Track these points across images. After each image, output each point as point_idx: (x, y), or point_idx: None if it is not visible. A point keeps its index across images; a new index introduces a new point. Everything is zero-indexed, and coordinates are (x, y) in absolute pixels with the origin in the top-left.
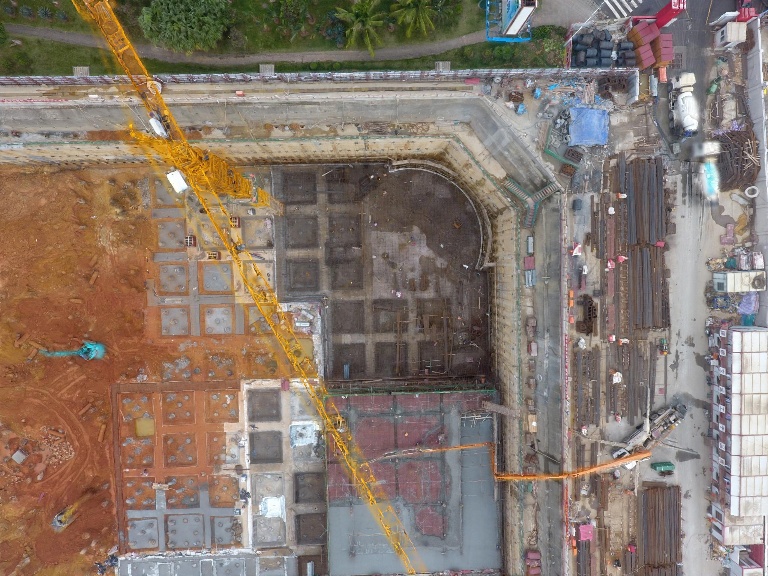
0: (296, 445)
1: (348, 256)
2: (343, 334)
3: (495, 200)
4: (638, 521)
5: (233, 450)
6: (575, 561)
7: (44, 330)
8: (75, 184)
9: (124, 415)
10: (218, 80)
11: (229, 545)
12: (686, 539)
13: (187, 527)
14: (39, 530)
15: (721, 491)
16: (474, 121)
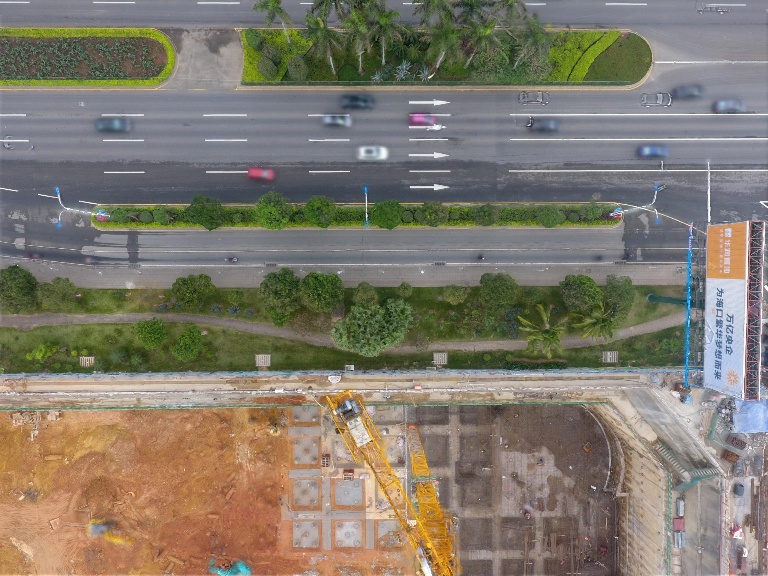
0: None
1: (477, 473)
2: (471, 550)
3: (638, 448)
4: None
5: None
6: None
7: (183, 547)
8: None
9: None
10: (394, 368)
11: None
12: None
13: None
14: None
15: None
16: (630, 392)
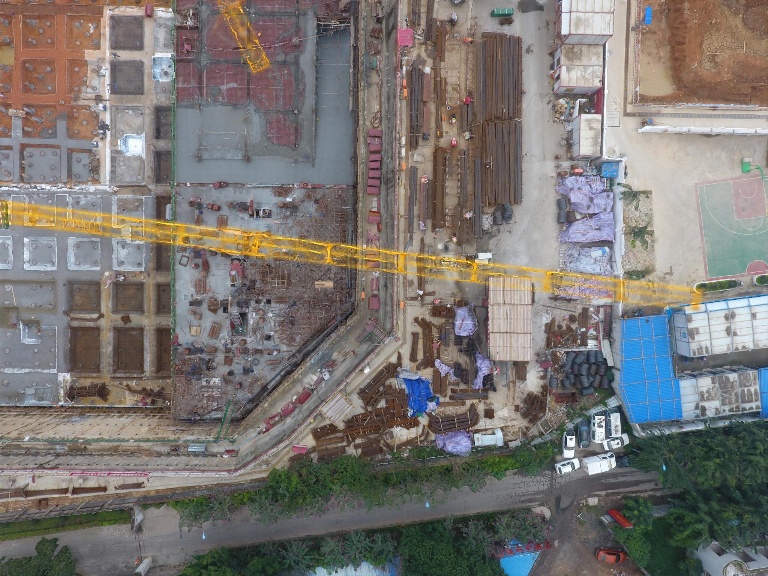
0: (159, 80)
1: None
2: None
3: None
4: (477, 75)
5: (94, 82)
6: (408, 113)
7: None
8: None
9: None
10: None
11: (86, 182)
12: (527, 98)
13: (44, 161)
14: None
15: (557, 23)
16: None
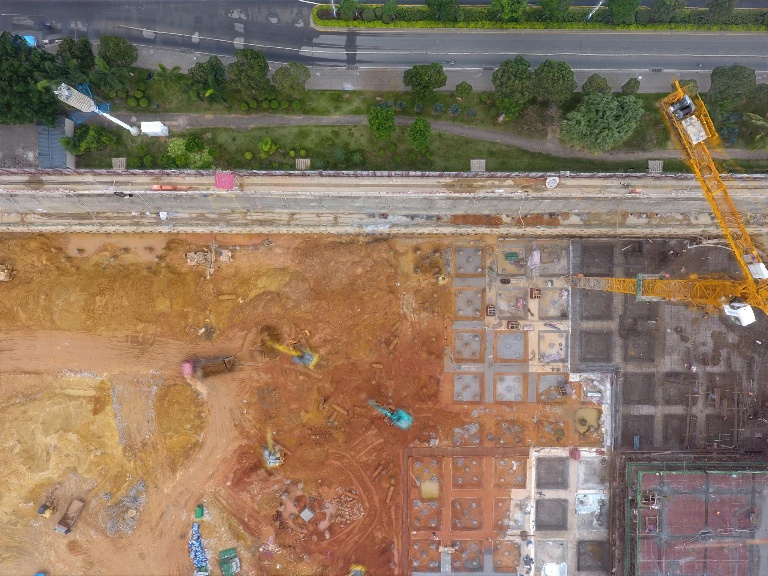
0: (579, 513)
1: (639, 328)
2: (633, 405)
3: None
4: None
5: (517, 516)
6: None
7: (349, 394)
8: (388, 254)
9: (413, 478)
10: None
11: None
12: None
13: None
14: None
15: None
16: None
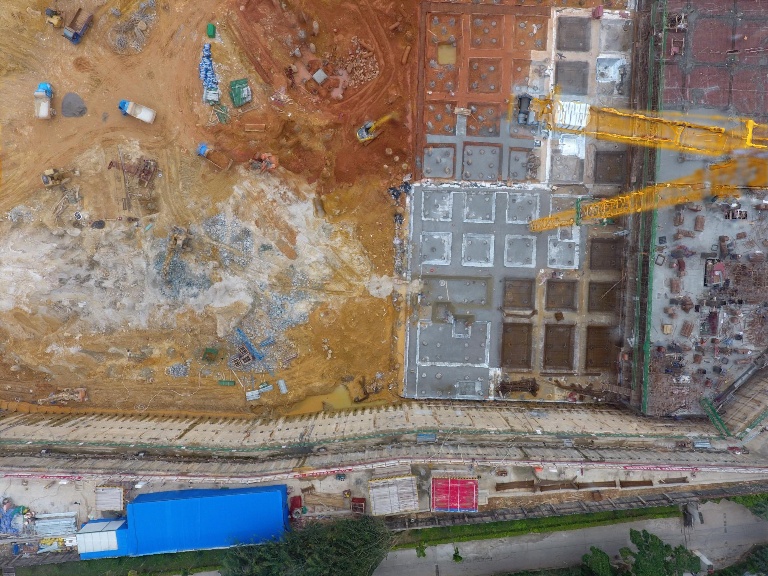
0: (599, 81)
1: None
2: None
3: None
4: None
5: (535, 82)
6: None
7: None
8: None
9: (431, 36)
10: None
11: (524, 180)
12: None
13: (483, 159)
14: (340, 146)
15: None
16: None
